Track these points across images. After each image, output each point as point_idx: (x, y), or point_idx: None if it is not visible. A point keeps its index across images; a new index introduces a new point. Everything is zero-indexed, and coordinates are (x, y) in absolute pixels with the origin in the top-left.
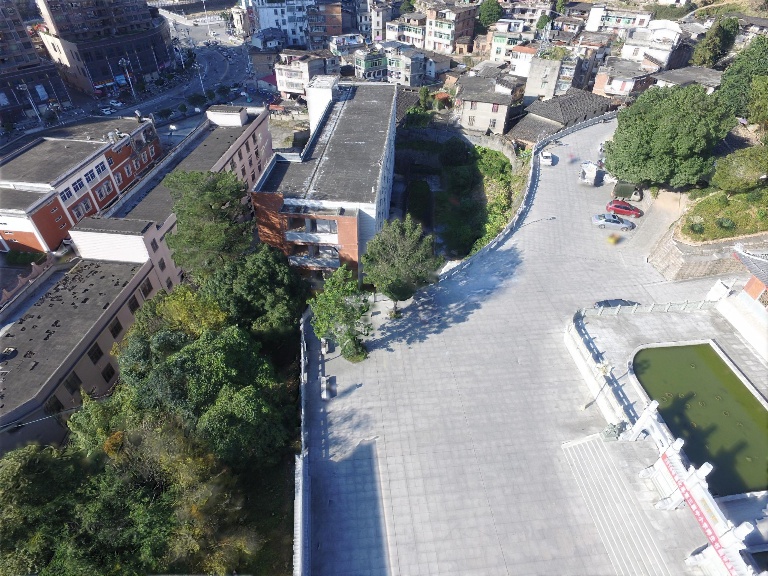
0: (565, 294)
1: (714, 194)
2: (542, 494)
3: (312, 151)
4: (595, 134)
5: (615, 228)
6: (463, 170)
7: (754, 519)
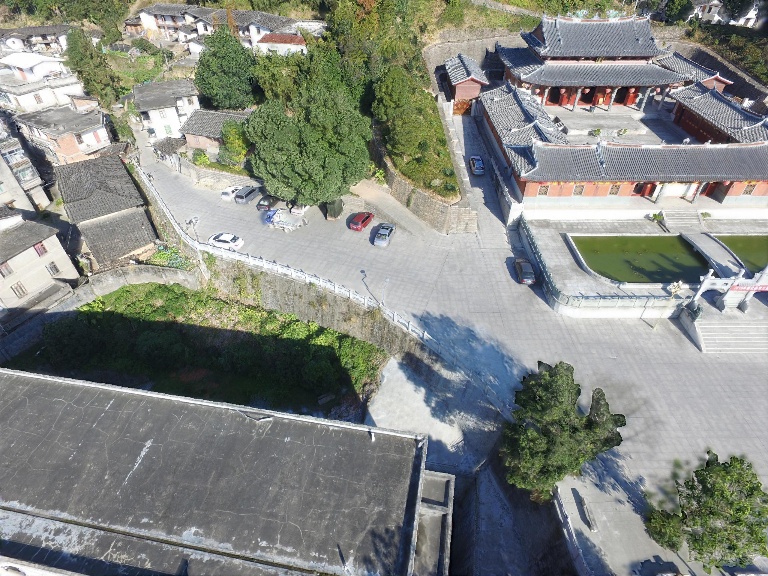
0: (503, 299)
1: (395, 162)
2: (760, 378)
3: (136, 572)
4: (182, 192)
5: (392, 236)
6: (155, 338)
7: (733, 272)
